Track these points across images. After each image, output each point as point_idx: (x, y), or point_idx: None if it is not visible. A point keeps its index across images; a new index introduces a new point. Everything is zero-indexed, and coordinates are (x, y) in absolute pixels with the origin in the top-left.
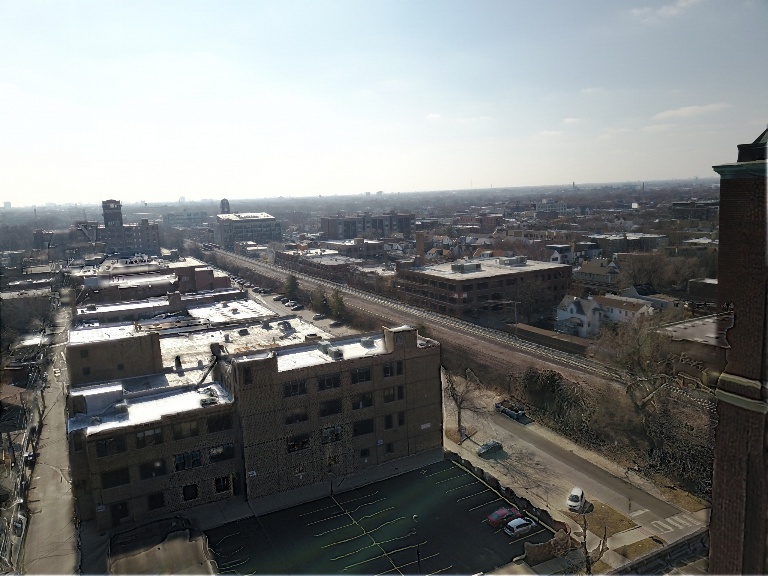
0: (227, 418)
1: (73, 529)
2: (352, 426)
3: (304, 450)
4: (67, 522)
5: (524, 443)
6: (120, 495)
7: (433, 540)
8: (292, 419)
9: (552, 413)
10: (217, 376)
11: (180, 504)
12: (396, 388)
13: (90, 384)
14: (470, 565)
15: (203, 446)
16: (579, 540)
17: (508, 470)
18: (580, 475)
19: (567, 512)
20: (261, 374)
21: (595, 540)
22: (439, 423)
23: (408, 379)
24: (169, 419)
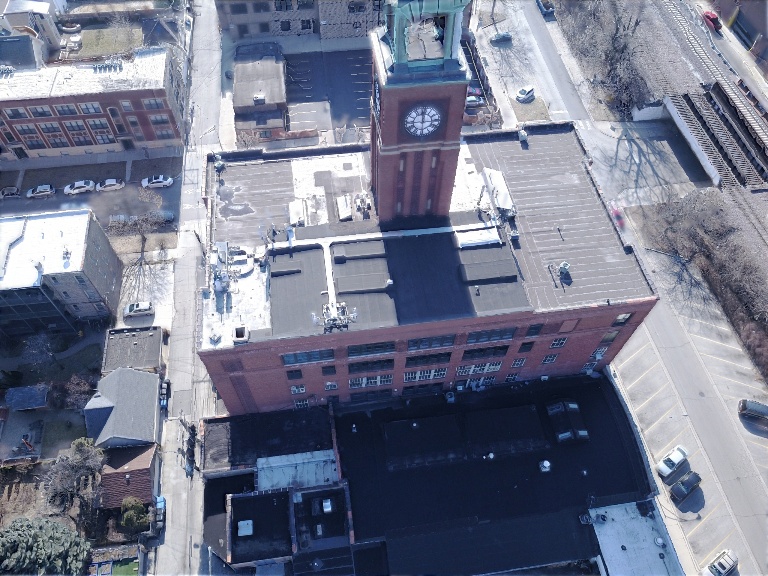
0: None
1: (218, 34)
2: None
3: (361, 13)
4: (215, 28)
5: (531, 39)
6: (242, 20)
7: None
8: None
9: (572, 17)
10: None
11: (279, 32)
12: None
13: None
14: None
15: None
16: (504, 119)
17: (501, 59)
18: (548, 76)
19: (513, 99)
20: None
21: (513, 121)
22: (468, 10)
23: None
24: None
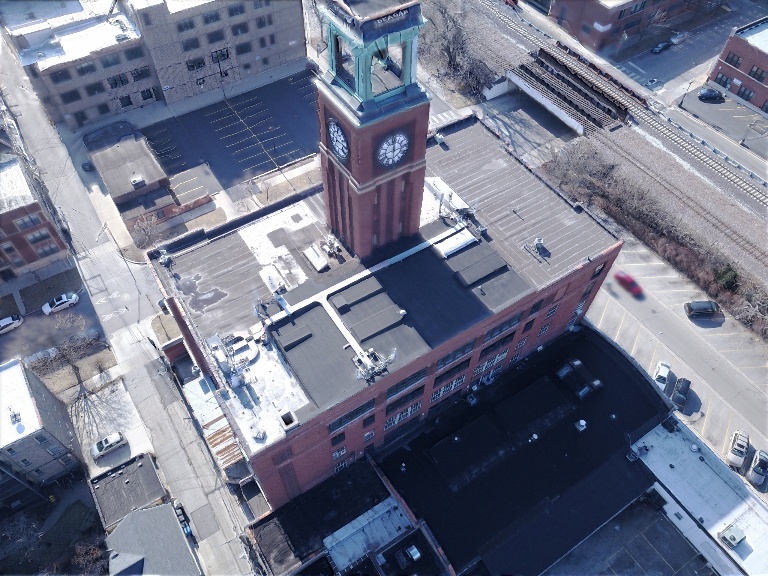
0: (139, 49)
1: (52, 129)
2: (235, 48)
3: (201, 68)
4: (45, 124)
5: None
6: (77, 108)
7: (290, 133)
8: (188, 48)
9: None
10: (121, 8)
11: (120, 109)
12: (266, 16)
13: (9, 0)
14: (309, 149)
15: (126, 70)
16: None
17: None
18: None
19: None
20: (157, 17)
21: None
22: (303, 40)
23: (275, 9)
24: (96, 54)
